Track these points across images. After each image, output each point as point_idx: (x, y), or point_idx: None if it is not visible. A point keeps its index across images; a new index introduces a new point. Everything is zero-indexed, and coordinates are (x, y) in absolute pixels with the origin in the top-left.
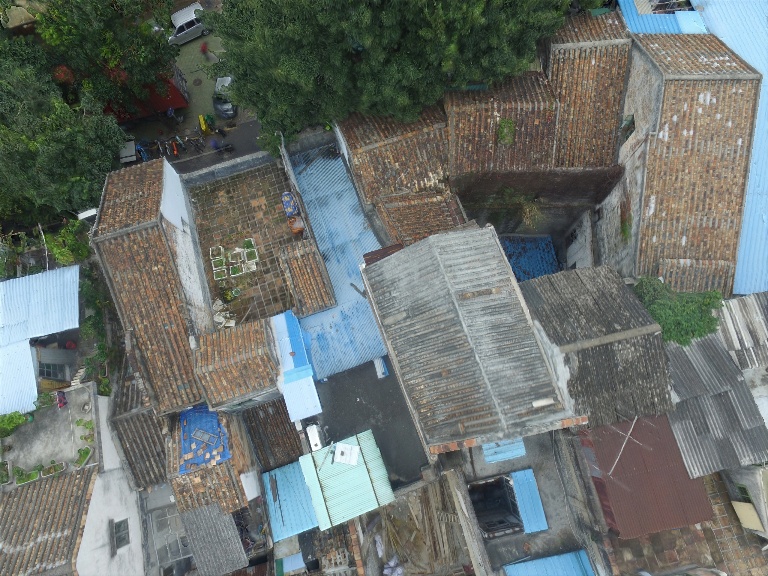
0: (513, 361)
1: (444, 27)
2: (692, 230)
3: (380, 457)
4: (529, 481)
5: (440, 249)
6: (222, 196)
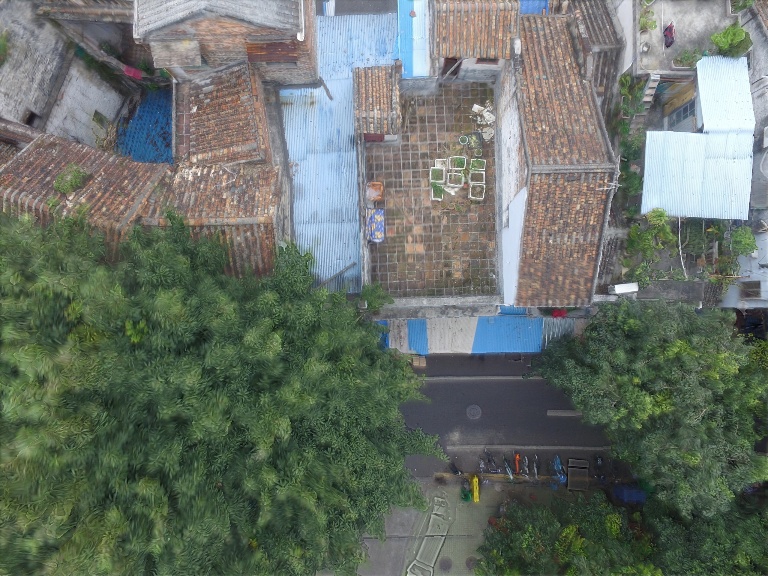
0: None
1: None
2: None
3: None
4: None
5: None
6: (457, 270)
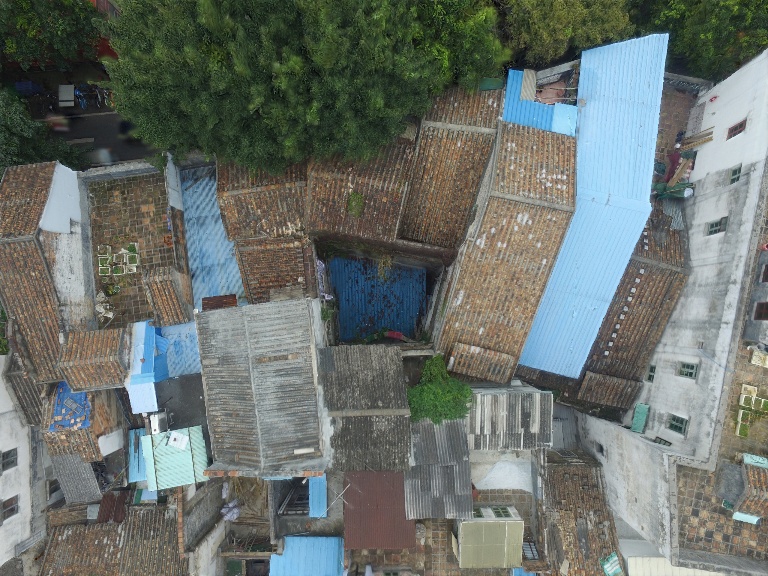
0: (289, 416)
1: (285, 121)
2: (490, 324)
3: (204, 447)
4: (321, 482)
5: (250, 318)
6: (117, 196)
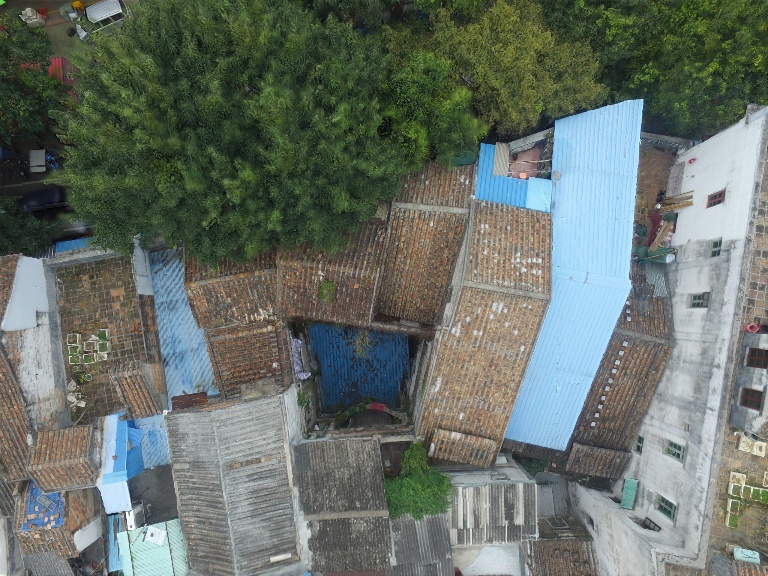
0: (264, 522)
1: (246, 226)
2: (470, 409)
3: None
4: None
5: (220, 423)
6: (85, 281)
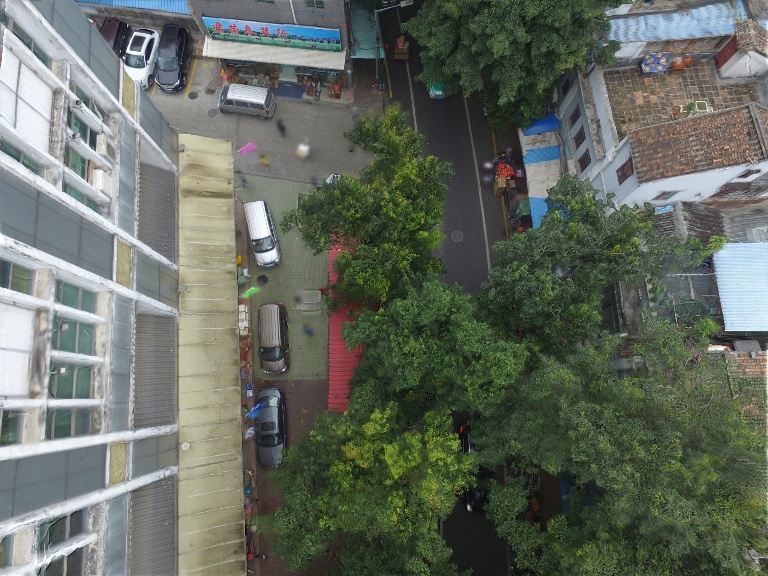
0: None
1: None
2: None
3: None
4: None
5: None
6: (628, 127)
